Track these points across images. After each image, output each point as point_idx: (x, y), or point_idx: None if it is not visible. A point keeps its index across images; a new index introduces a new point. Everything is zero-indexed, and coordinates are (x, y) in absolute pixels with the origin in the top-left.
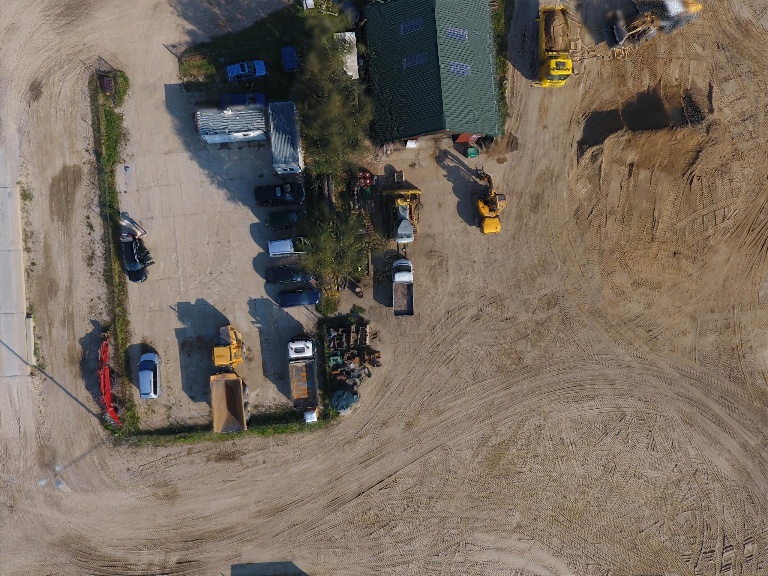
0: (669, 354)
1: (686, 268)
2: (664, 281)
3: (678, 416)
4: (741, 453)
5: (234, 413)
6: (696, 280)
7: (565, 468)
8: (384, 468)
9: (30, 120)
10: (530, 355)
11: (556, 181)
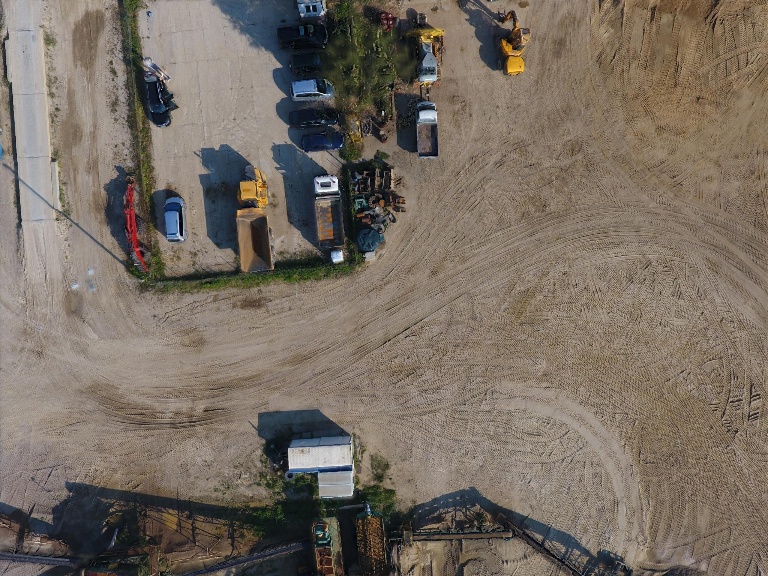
0: (694, 200)
1: (710, 113)
2: (688, 126)
3: (703, 264)
4: (767, 301)
5: (260, 254)
6: (720, 125)
7: (591, 316)
8: (410, 315)
9: None
10: (554, 201)
11: (578, 26)
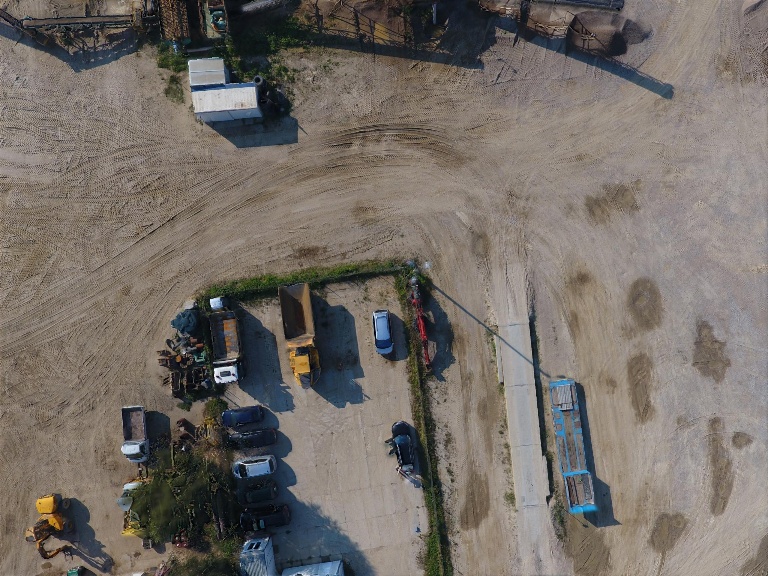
0: None
1: None
2: None
3: None
4: None
5: (295, 302)
6: None
7: None
8: (149, 247)
9: (510, 570)
10: (5, 369)
11: None
